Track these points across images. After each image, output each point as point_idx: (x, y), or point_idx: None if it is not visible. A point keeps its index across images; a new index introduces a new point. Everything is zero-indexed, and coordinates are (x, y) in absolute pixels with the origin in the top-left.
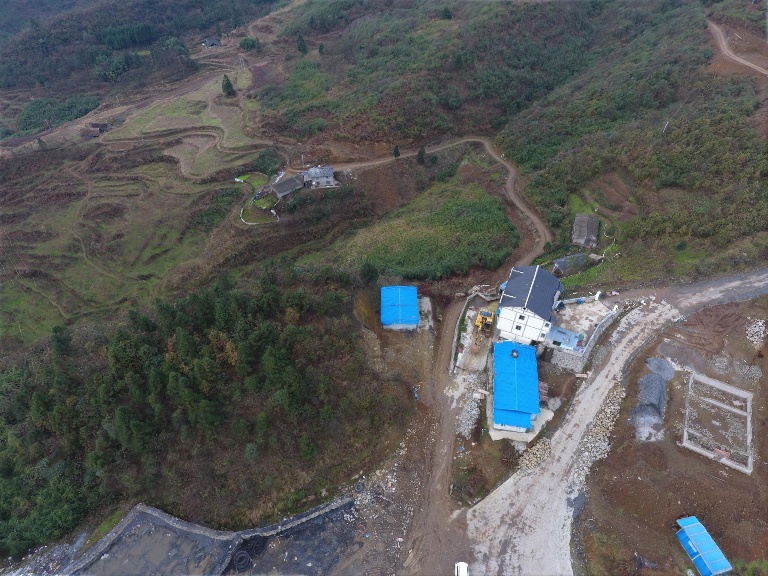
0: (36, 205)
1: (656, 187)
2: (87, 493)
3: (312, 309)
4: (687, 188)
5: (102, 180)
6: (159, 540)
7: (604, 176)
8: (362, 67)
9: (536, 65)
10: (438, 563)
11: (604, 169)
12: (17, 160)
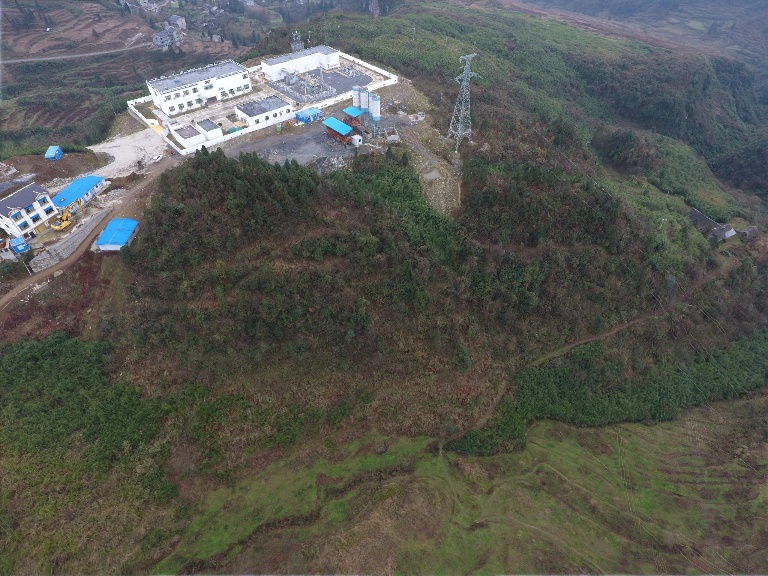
0: None
1: None
2: None
3: None
4: None
5: None
6: None
7: None
8: None
9: None
10: (165, 163)
11: None
12: None
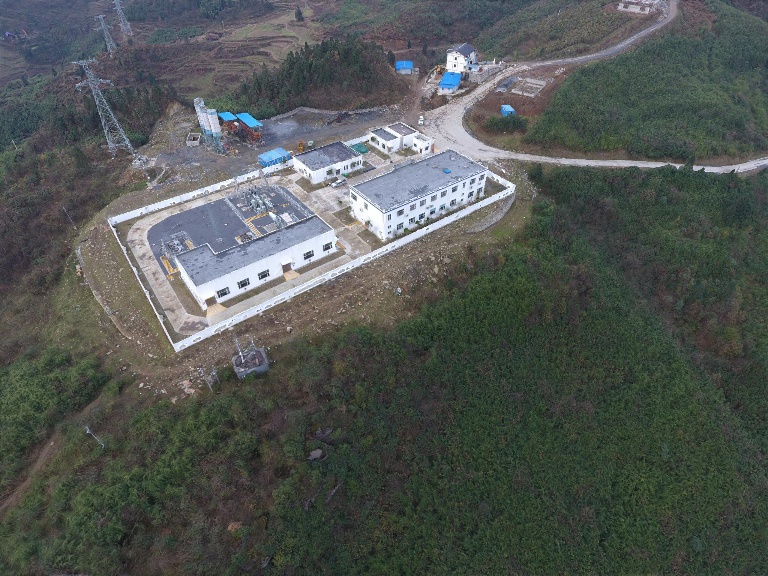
0: (185, 74)
1: (546, 39)
2: (279, 108)
3: (367, 48)
4: (561, 38)
5: (223, 63)
6: (310, 115)
7: (525, 42)
8: (389, 0)
9: (506, 0)
10: None
11: (525, 38)
12: (172, 48)
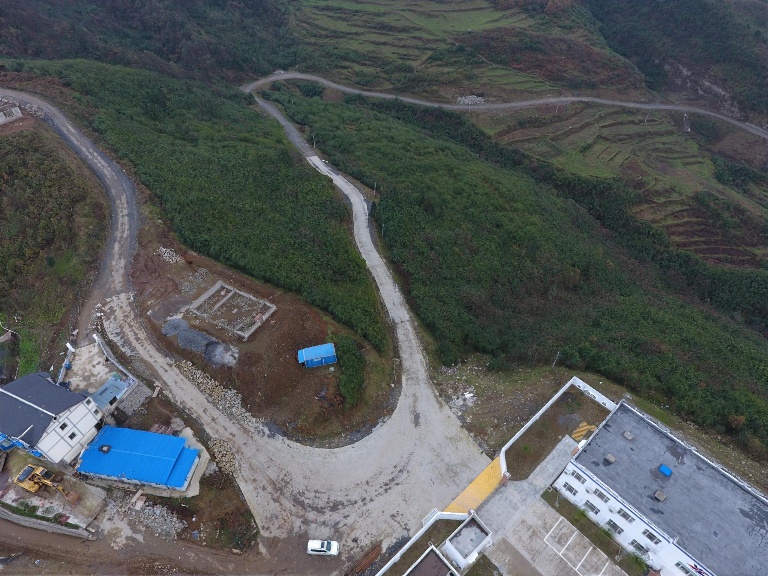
0: None
1: None
2: None
3: None
4: None
5: None
6: None
7: None
8: None
9: None
10: (305, 573)
11: None
12: None
